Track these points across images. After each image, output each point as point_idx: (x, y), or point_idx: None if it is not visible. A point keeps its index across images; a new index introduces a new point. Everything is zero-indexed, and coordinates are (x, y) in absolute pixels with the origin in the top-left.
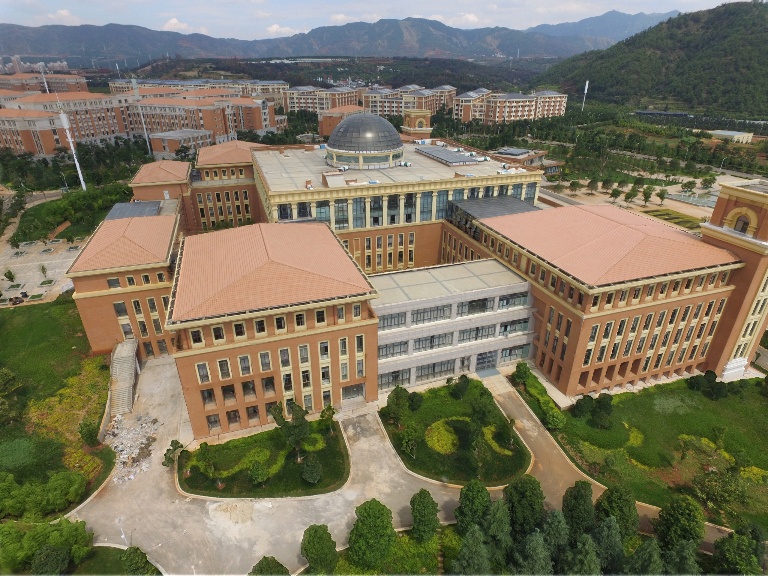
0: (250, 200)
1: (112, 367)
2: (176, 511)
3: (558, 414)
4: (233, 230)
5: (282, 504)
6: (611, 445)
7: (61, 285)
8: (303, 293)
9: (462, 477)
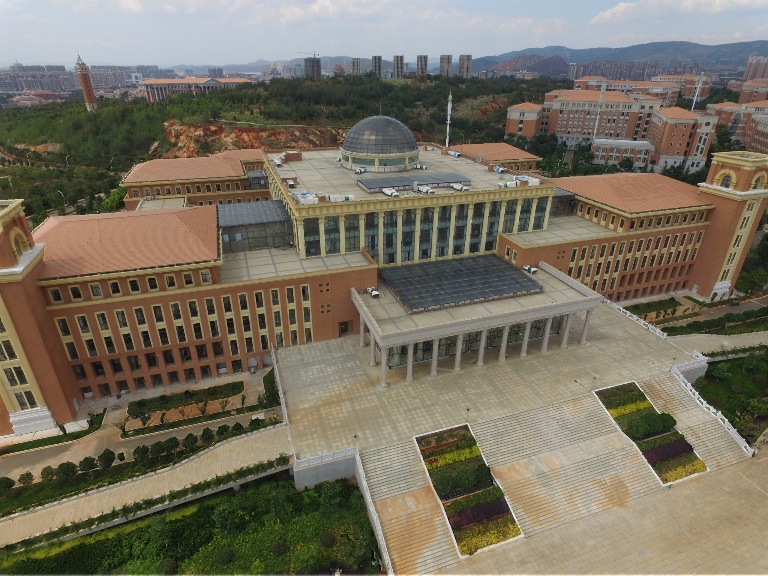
0: None
1: None
2: None
3: None
4: None
5: None
6: None
7: None
8: None
9: None
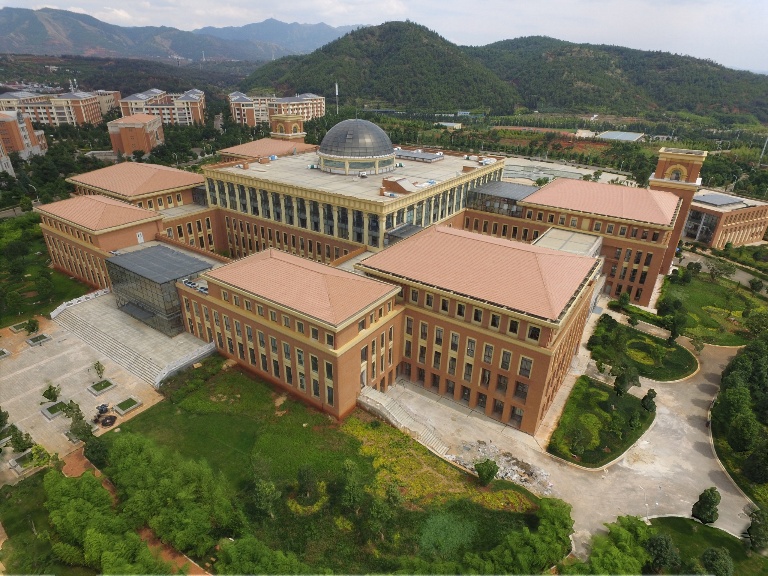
0: (213, 228)
1: (391, 418)
2: (615, 481)
3: None
4: (416, 242)
5: (650, 437)
6: None
7: (128, 381)
8: (577, 272)
9: (682, 372)
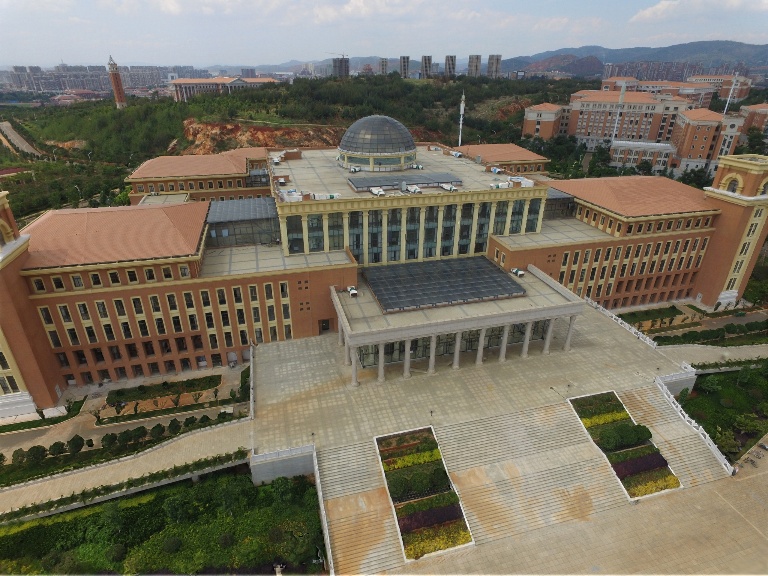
0: None
1: None
2: None
3: None
4: None
5: None
6: None
7: None
8: None
9: None
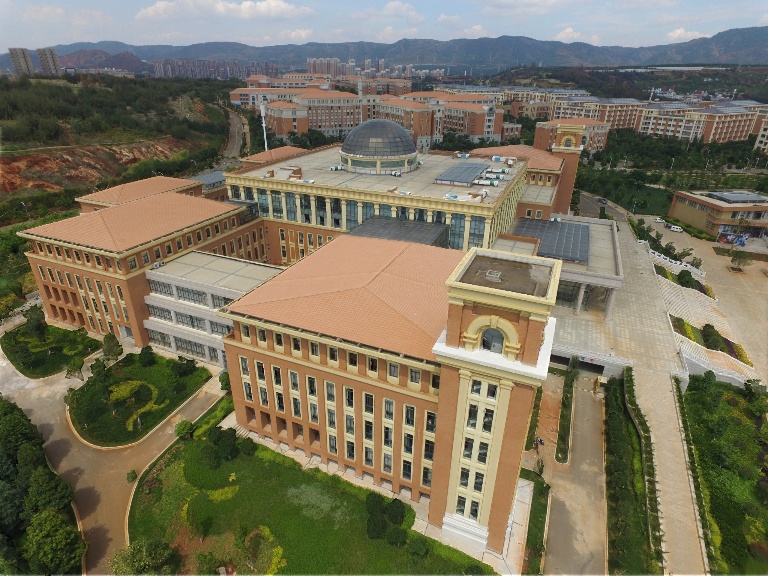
0: None
1: None
2: None
3: (183, 424)
4: None
5: (7, 368)
6: (192, 480)
7: None
8: (87, 238)
9: (81, 419)
